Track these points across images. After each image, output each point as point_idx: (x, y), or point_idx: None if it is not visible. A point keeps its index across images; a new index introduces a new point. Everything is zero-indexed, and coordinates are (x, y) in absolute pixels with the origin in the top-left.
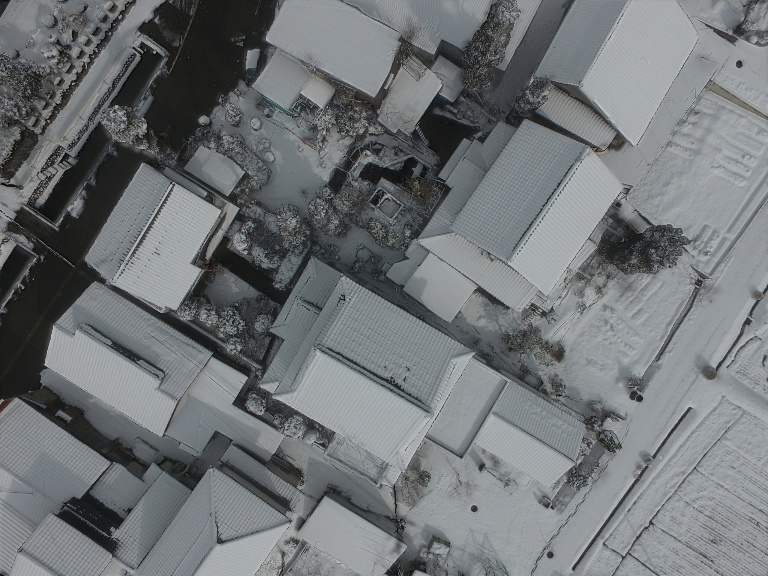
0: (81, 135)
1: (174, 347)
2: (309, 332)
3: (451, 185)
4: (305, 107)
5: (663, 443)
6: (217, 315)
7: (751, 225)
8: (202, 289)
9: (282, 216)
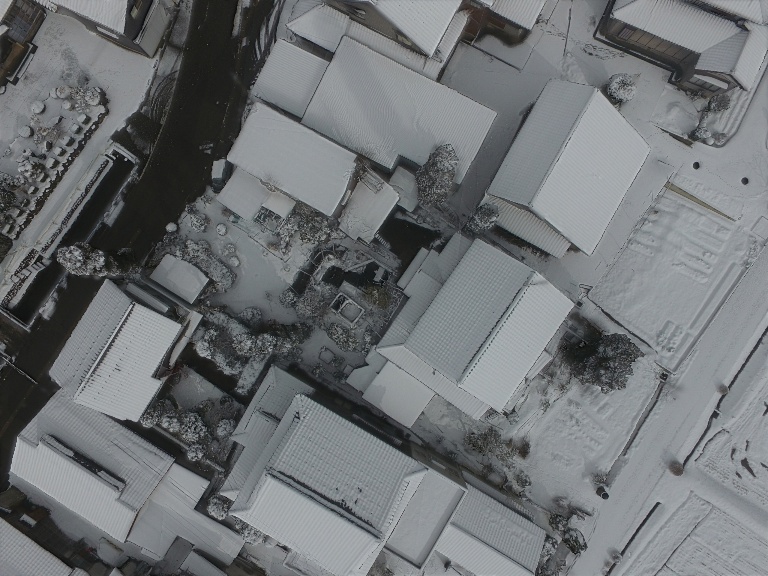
0: (54, 238)
1: (136, 455)
2: (265, 448)
3: (409, 294)
4: (268, 215)
5: (632, 539)
6: (179, 422)
7: (715, 319)
8: (168, 390)
9: (237, 338)
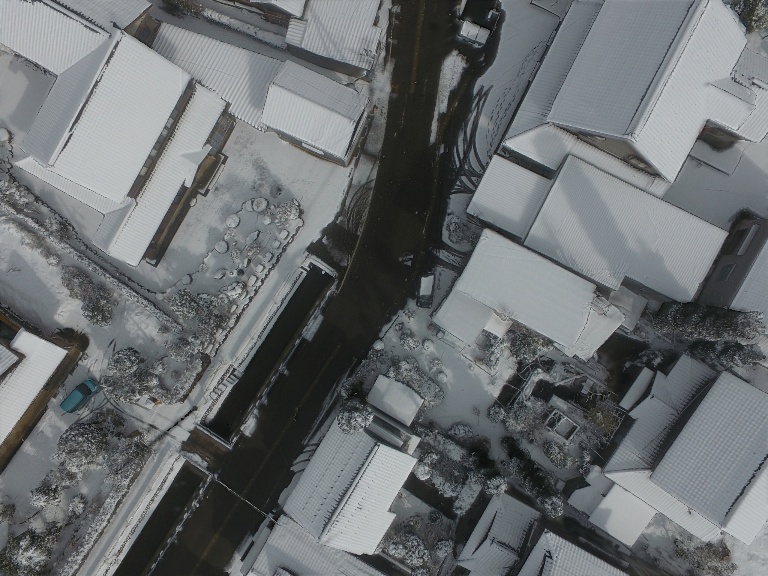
0: (249, 351)
1: None
2: None
3: (635, 417)
4: None
5: None
6: (404, 549)
7: None
8: None
9: (493, 483)
